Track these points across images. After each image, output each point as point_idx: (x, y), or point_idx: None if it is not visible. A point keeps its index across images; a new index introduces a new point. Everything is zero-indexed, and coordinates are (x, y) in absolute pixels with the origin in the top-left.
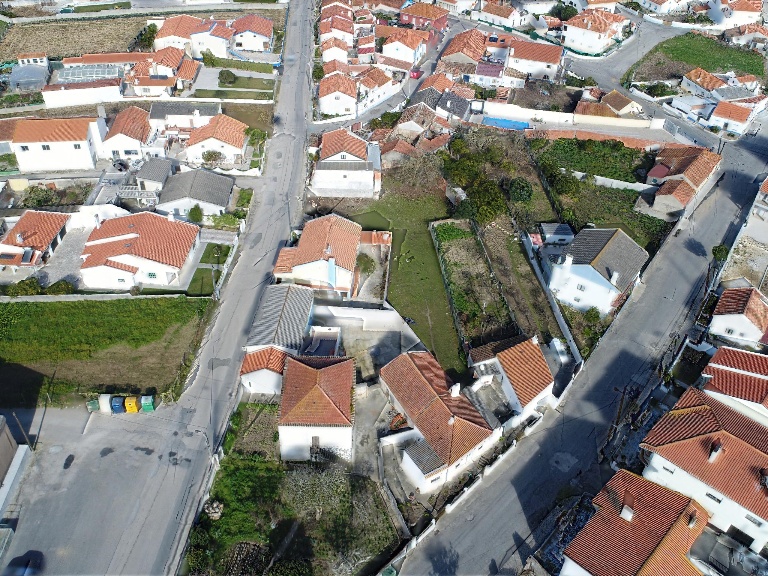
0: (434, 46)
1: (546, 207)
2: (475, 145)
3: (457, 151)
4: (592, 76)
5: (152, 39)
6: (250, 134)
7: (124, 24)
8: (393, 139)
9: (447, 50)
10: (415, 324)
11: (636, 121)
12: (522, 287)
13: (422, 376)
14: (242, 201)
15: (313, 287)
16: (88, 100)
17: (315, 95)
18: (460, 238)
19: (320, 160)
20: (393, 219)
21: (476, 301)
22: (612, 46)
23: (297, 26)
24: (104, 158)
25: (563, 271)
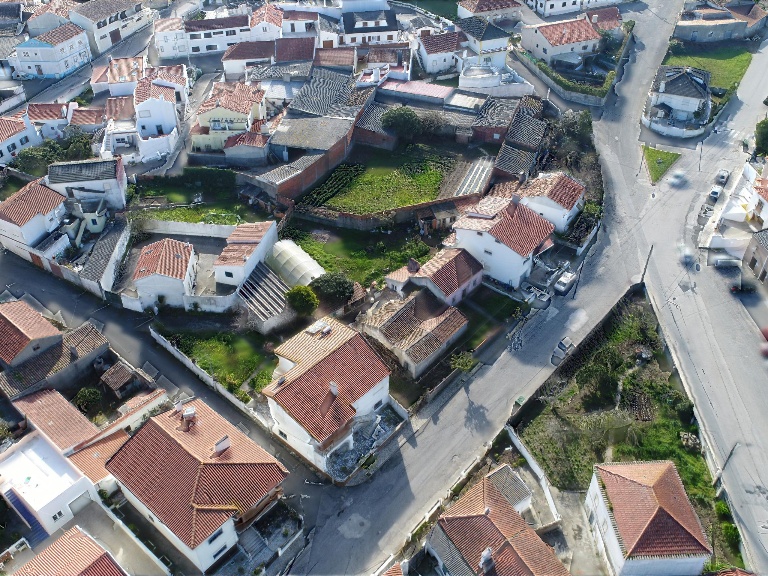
0: None
1: None
2: None
3: None
4: None
5: None
6: None
7: None
8: None
9: None
10: None
11: None
12: None
13: (533, 571)
14: None
15: None
16: None
17: None
18: None
19: None
20: None
21: None
22: None
23: None
24: None
25: None
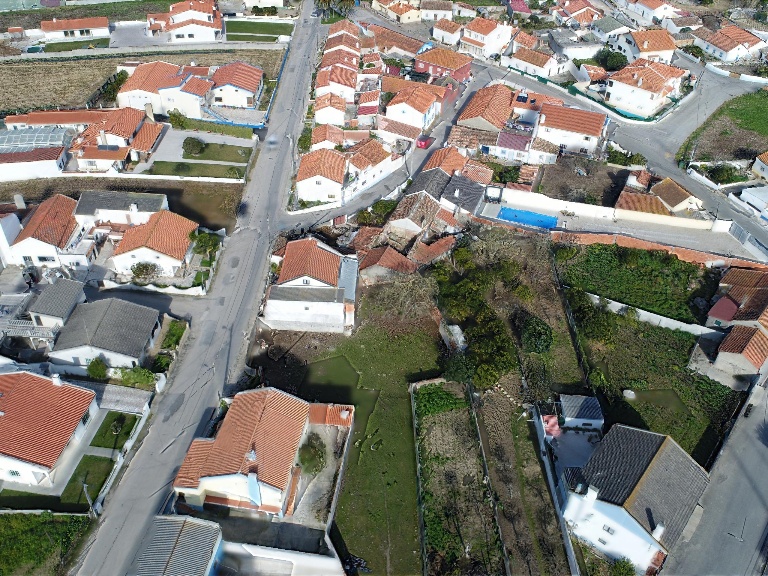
0: (452, 102)
1: (570, 359)
2: (484, 256)
3: (460, 264)
4: (640, 149)
5: (117, 91)
6: (196, 239)
7: (95, 67)
8: (382, 240)
9: (465, 111)
10: (366, 571)
11: (694, 221)
12: (526, 504)
13: None
14: (170, 339)
15: (230, 503)
16: (20, 175)
17: (296, 172)
18: (449, 410)
19: (276, 284)
20: (364, 371)
21: (458, 530)
22: (667, 106)
23: (294, 73)
24: (14, 264)
25: (583, 504)
